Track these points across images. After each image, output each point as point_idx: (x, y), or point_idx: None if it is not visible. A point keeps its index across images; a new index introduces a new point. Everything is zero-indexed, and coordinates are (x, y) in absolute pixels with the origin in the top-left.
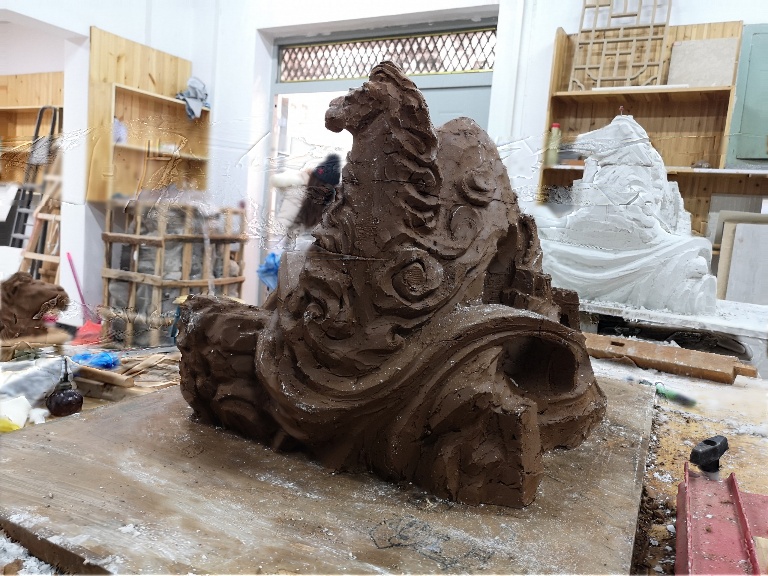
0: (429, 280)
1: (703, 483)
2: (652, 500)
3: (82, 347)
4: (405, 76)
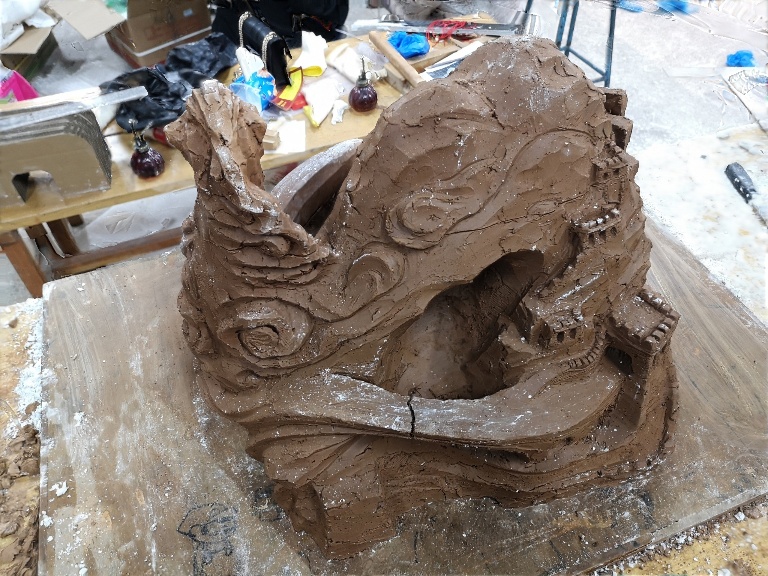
0: (281, 344)
1: None
2: None
3: (436, 4)
4: (213, 121)
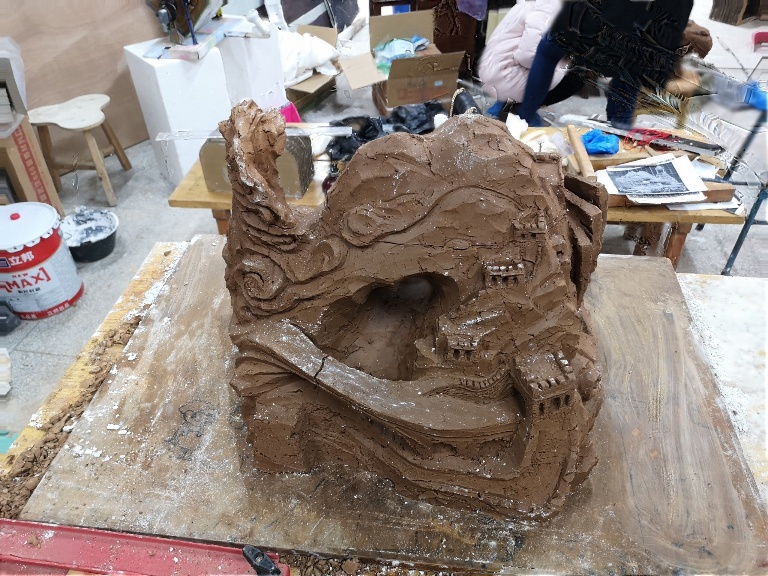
0: (263, 290)
1: (247, 568)
2: (342, 570)
3: None
4: (238, 122)
